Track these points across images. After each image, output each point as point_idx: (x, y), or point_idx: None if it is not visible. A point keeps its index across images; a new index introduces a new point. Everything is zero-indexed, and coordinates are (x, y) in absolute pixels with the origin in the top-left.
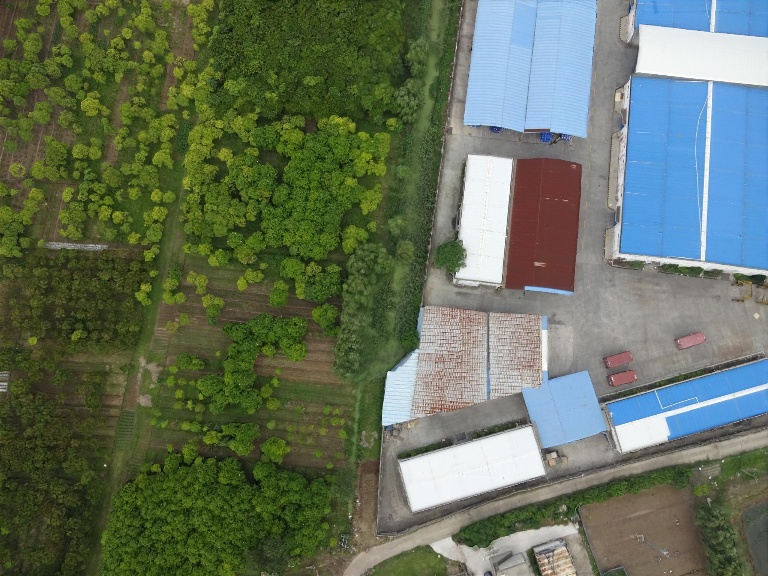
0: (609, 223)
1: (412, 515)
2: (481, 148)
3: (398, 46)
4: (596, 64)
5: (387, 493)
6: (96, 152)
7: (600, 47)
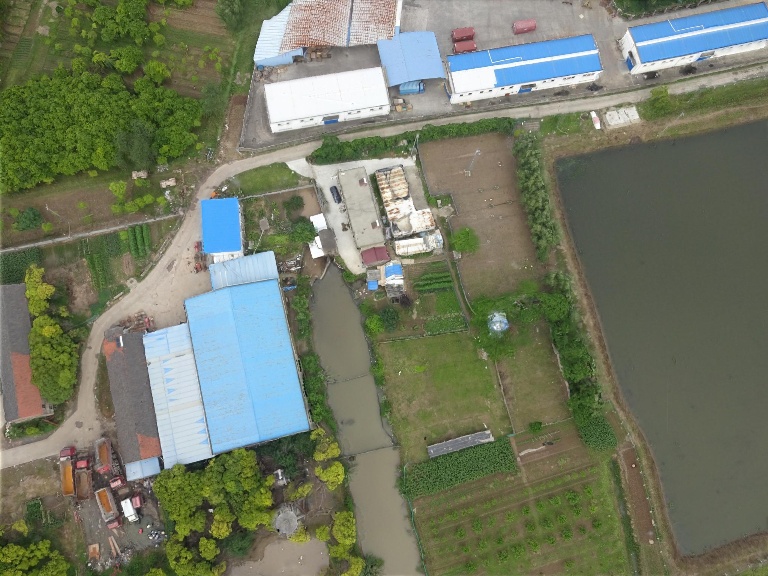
0: None
1: (273, 140)
2: None
3: None
4: None
5: (253, 121)
6: None
7: None
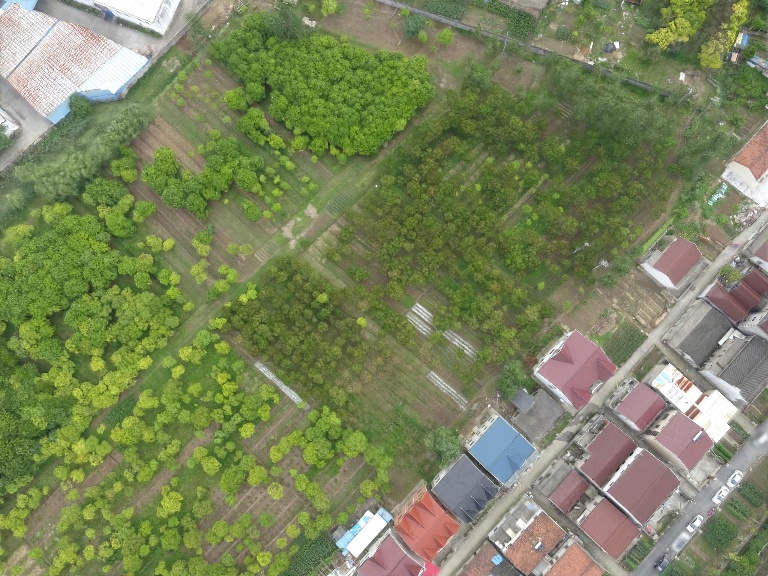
0: None
1: None
2: None
3: None
4: None
5: None
6: (197, 452)
7: None
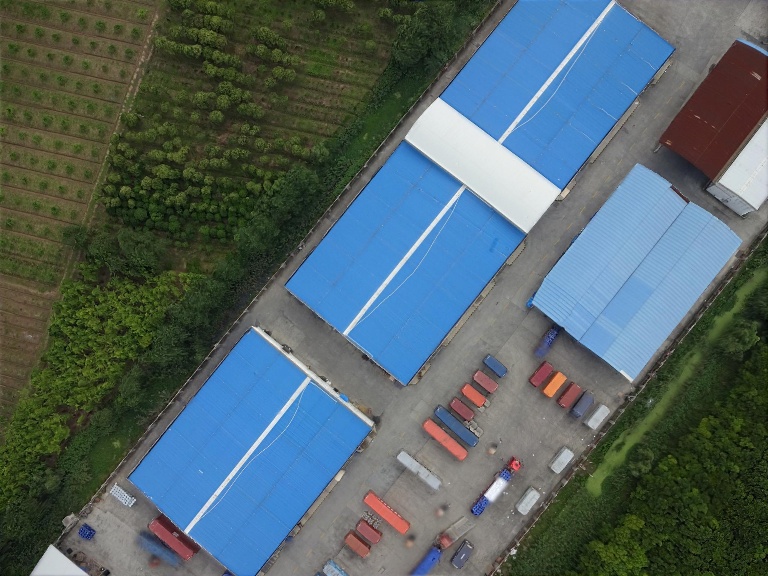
0: (647, 90)
1: None
2: None
3: (761, 357)
4: (563, 236)
5: None
6: None
7: (548, 250)
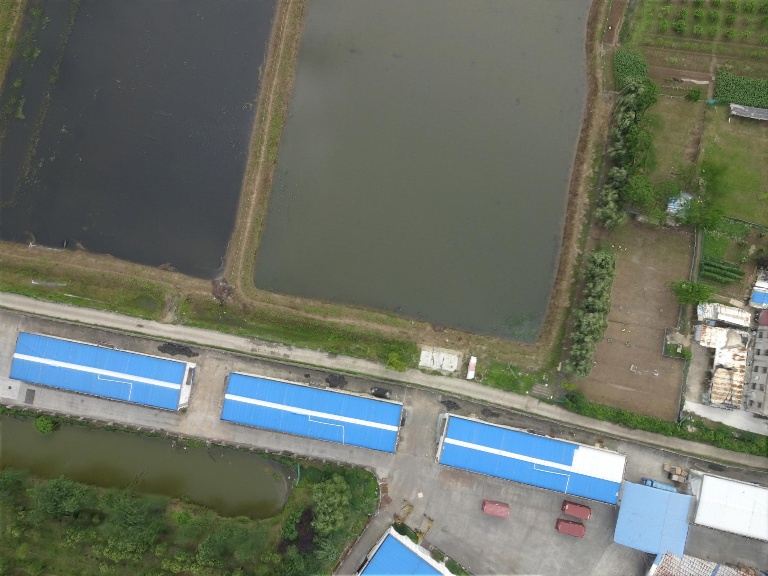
0: None
1: None
2: None
3: None
4: None
5: None
6: None
7: None
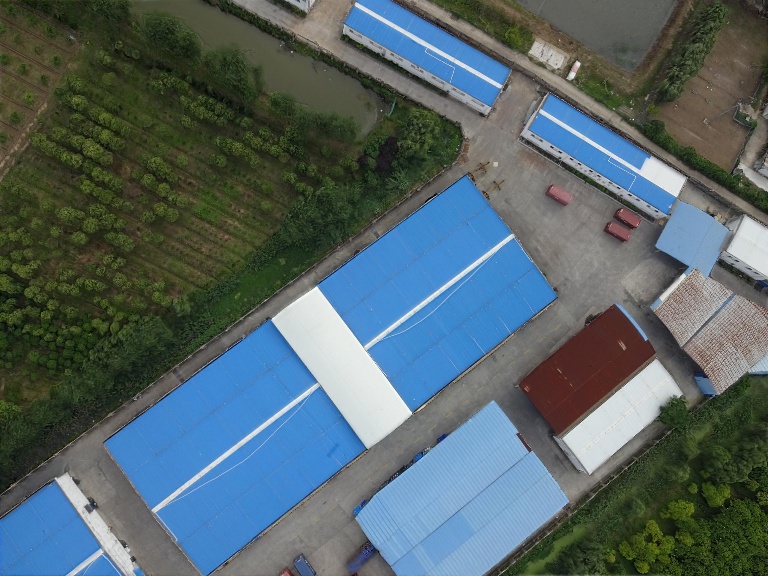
0: None
1: None
2: (557, 470)
3: None
4: (407, 449)
5: None
6: None
7: (389, 460)
